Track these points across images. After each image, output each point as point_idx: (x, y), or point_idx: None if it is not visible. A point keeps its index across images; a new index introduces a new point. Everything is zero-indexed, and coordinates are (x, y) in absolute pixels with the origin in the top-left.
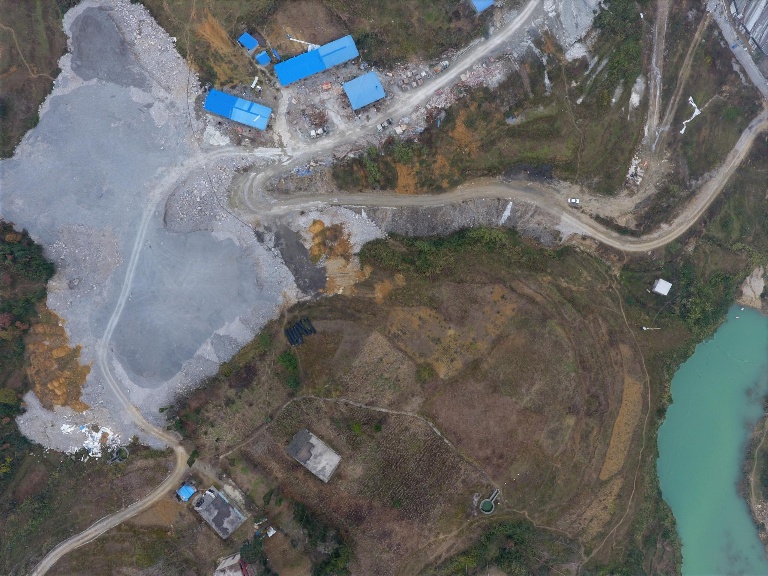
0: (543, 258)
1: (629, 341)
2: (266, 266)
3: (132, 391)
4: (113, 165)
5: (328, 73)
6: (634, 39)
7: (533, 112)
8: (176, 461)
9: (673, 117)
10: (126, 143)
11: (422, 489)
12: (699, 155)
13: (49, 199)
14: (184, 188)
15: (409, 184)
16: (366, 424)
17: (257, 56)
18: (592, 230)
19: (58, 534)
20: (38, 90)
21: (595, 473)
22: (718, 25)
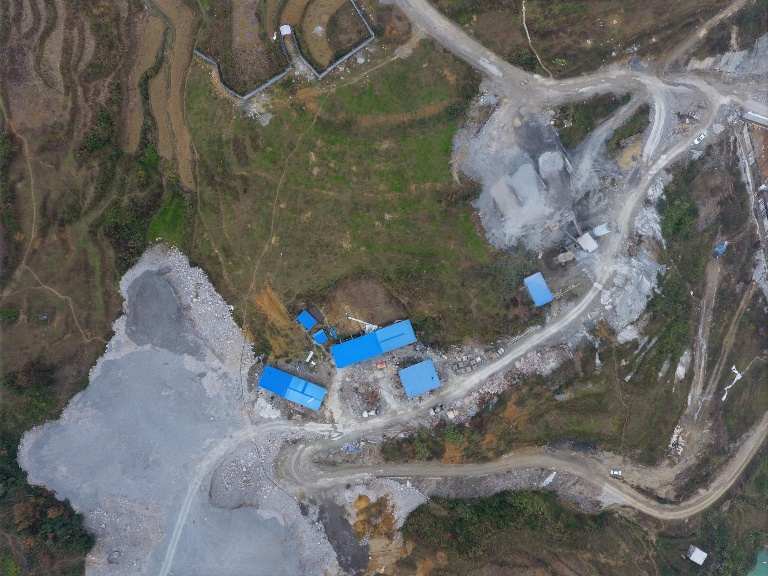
0: (584, 534)
1: None
2: (309, 542)
3: None
4: (161, 435)
5: (384, 353)
6: (684, 318)
7: (582, 389)
8: None
9: (716, 387)
10: (176, 413)
11: None
12: (738, 419)
13: (94, 468)
14: (231, 457)
15: (455, 456)
16: None
17: (314, 335)
18: (632, 500)
19: None
20: (90, 354)
21: None
22: (762, 291)
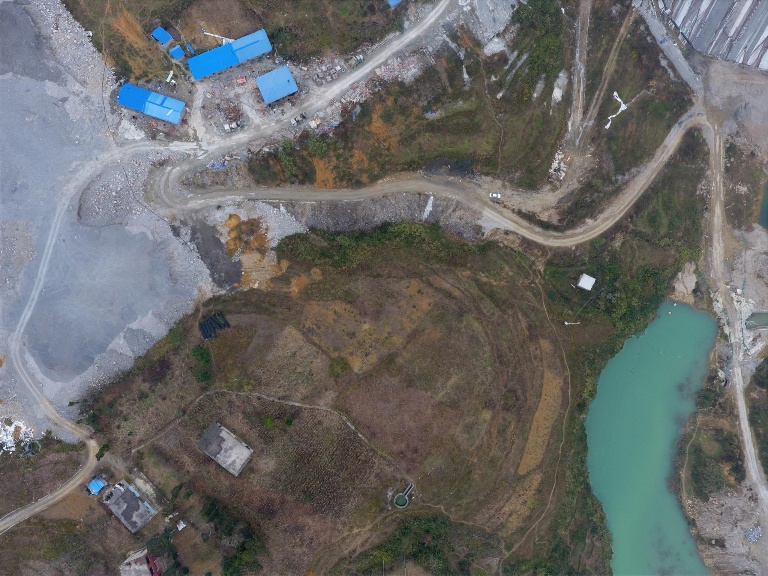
0: (463, 253)
1: (549, 336)
2: (181, 260)
3: (45, 385)
4: (27, 159)
5: (243, 67)
6: (555, 34)
7: (452, 107)
8: (88, 455)
9: (597, 112)
10: (41, 137)
11: (335, 483)
12: (625, 150)
13: None
14: (100, 182)
15: (328, 178)
16: (279, 418)
17: (171, 50)
18: (514, 225)
19: None
20: None
21: (513, 468)
22: (645, 20)
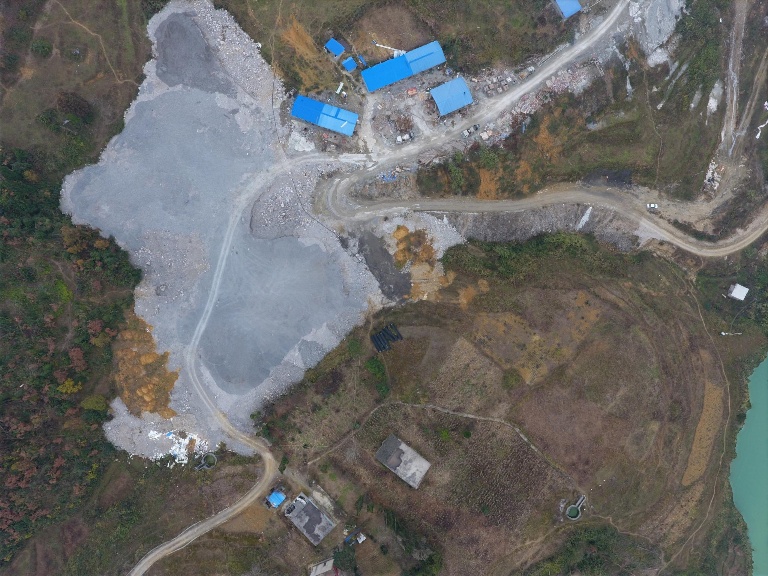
0: (624, 263)
1: (709, 346)
2: (351, 272)
3: (220, 397)
4: (199, 171)
5: (413, 79)
6: (714, 44)
7: (614, 117)
8: (264, 467)
9: (749, 122)
10: (212, 149)
11: (509, 495)
12: None
13: (135, 205)
14: (269, 194)
15: (491, 189)
16: (454, 430)
17: (343, 62)
18: (670, 235)
19: (149, 541)
20: (123, 96)
21: (678, 479)
22: None
